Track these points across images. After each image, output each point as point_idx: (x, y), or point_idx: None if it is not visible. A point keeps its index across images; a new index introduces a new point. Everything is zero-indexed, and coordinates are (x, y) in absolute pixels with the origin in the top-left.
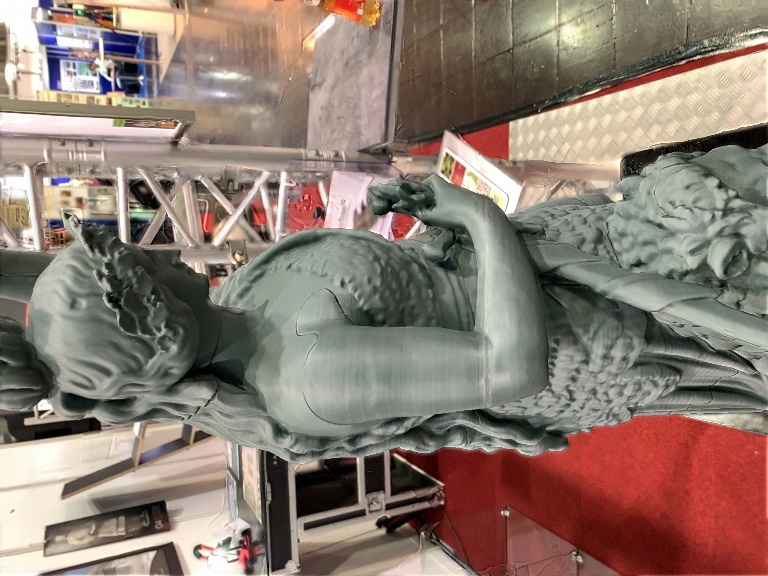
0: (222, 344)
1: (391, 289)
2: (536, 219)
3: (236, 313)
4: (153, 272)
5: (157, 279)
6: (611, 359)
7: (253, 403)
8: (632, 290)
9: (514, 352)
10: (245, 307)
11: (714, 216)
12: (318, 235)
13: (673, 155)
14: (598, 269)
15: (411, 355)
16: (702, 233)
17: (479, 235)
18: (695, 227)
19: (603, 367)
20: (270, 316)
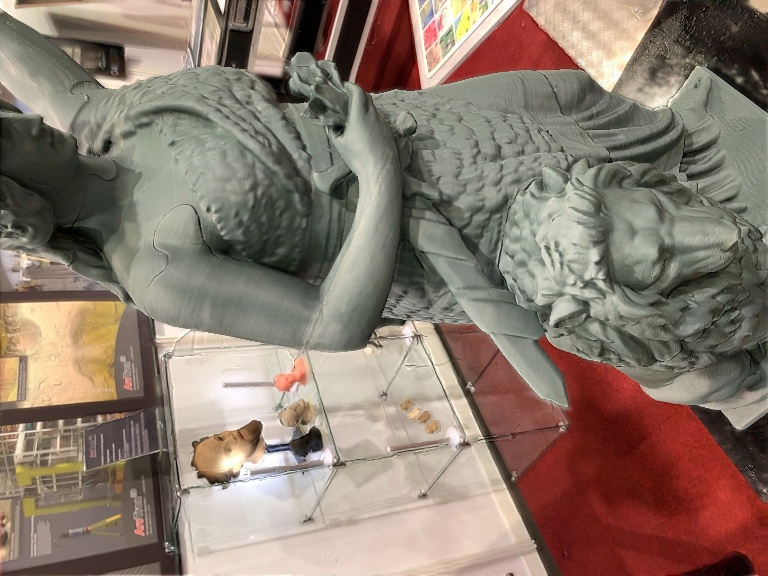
0: (85, 214)
1: (259, 222)
2: (453, 161)
3: (106, 179)
4: (4, 157)
5: (8, 165)
6: (451, 310)
7: (106, 278)
8: (472, 307)
9: (338, 332)
10: (124, 155)
11: (575, 284)
12: (210, 119)
13: (590, 198)
14: (459, 270)
15: (247, 307)
16: (560, 287)
17: (363, 202)
18: (557, 280)
19: (442, 313)
20: (137, 201)
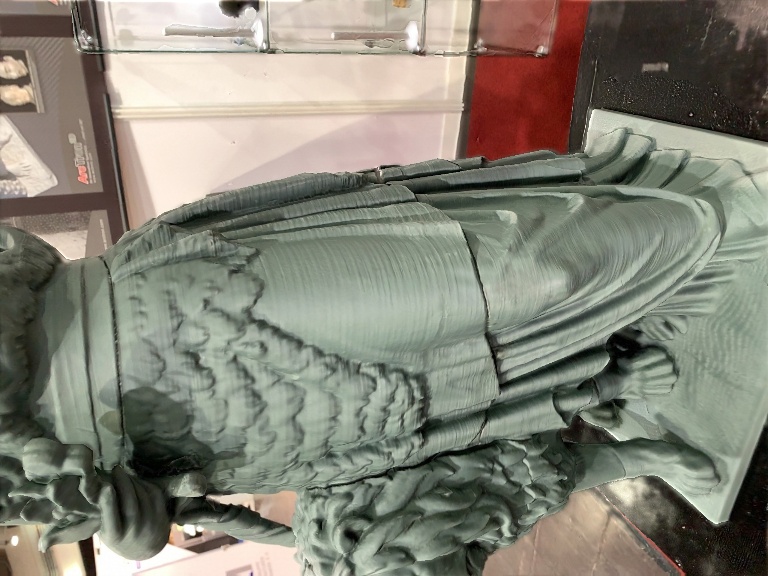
0: None
1: None
2: None
3: None
4: None
5: None
6: None
7: None
8: None
9: None
10: None
11: None
12: None
13: None
14: None
15: None
16: None
17: None
18: None
19: None
20: None
